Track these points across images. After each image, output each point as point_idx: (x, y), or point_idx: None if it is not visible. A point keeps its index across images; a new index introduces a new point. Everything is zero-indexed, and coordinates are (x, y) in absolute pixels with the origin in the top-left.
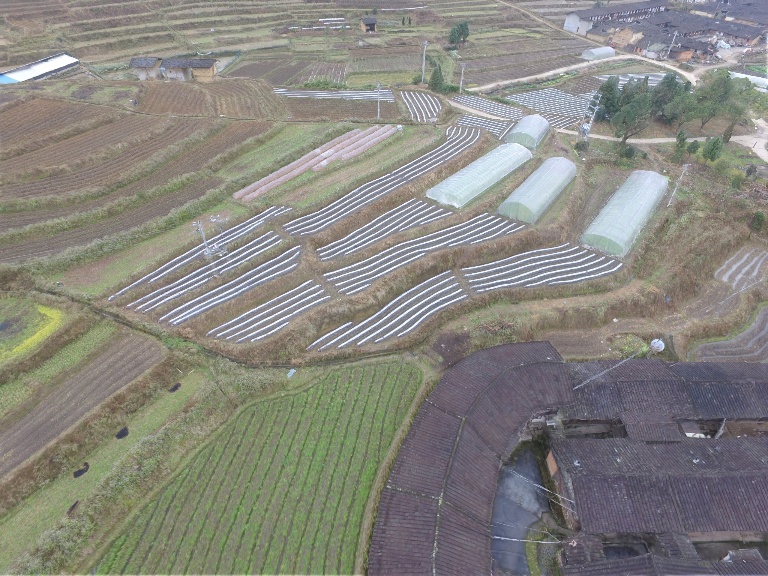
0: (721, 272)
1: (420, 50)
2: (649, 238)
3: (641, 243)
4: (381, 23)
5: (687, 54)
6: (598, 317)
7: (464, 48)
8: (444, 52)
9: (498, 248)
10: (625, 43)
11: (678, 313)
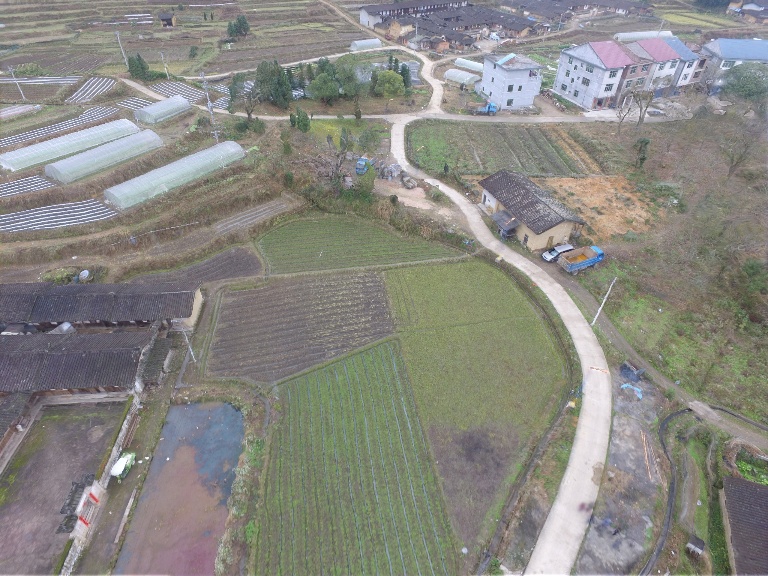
0: (222, 221)
1: (196, 43)
2: (173, 194)
3: (158, 198)
4: (184, 18)
5: (444, 45)
6: (50, 254)
7: (243, 41)
8: (216, 44)
9: (12, 202)
10: (397, 35)
11: (140, 252)
